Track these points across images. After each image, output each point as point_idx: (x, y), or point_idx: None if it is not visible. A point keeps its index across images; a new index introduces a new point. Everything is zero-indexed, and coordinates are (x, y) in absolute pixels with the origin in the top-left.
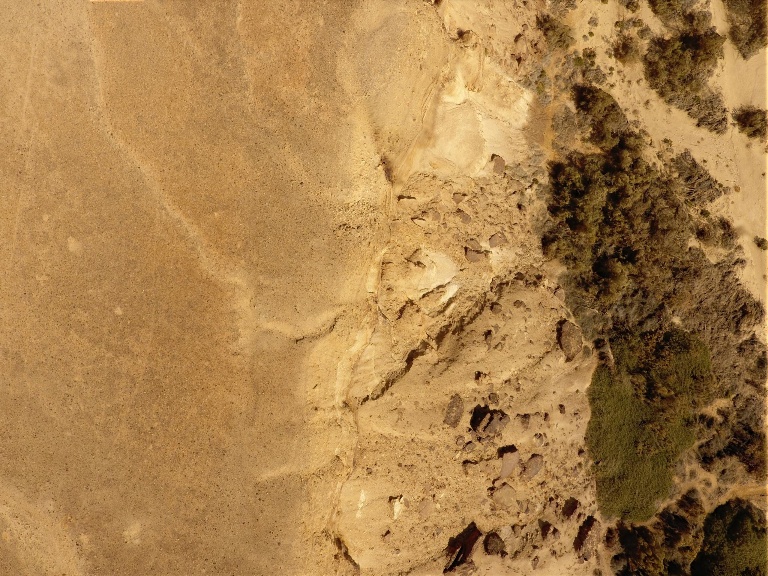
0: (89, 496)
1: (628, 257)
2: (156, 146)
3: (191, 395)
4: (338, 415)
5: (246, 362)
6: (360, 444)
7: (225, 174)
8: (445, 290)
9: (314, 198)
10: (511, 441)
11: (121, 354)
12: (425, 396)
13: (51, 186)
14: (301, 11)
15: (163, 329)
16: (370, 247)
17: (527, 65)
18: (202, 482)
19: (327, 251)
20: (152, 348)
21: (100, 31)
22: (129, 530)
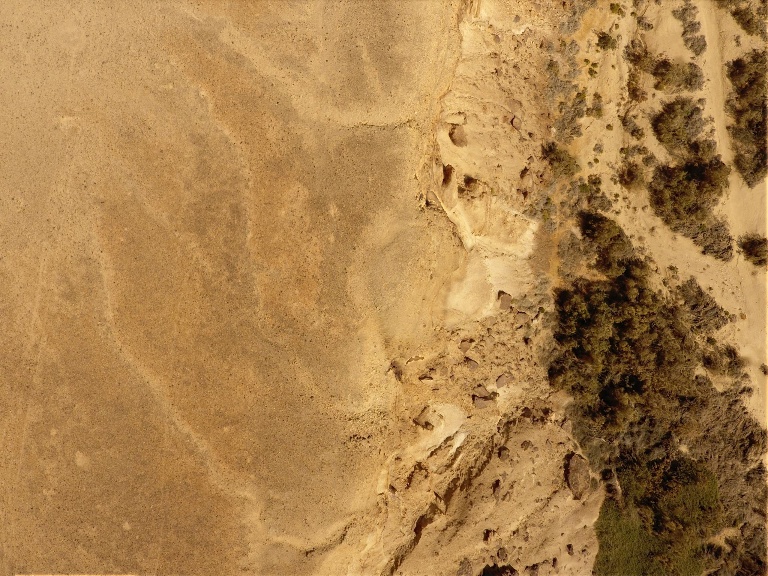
0: None
1: (635, 386)
2: (165, 361)
3: None
4: None
5: None
6: None
7: (235, 389)
8: (453, 443)
9: (324, 411)
10: None
11: (129, 569)
12: (434, 568)
13: (59, 401)
14: (311, 228)
15: (172, 544)
16: (380, 454)
17: (533, 195)
18: None
19: (337, 464)
20: (161, 564)
21: (109, 243)
22: None
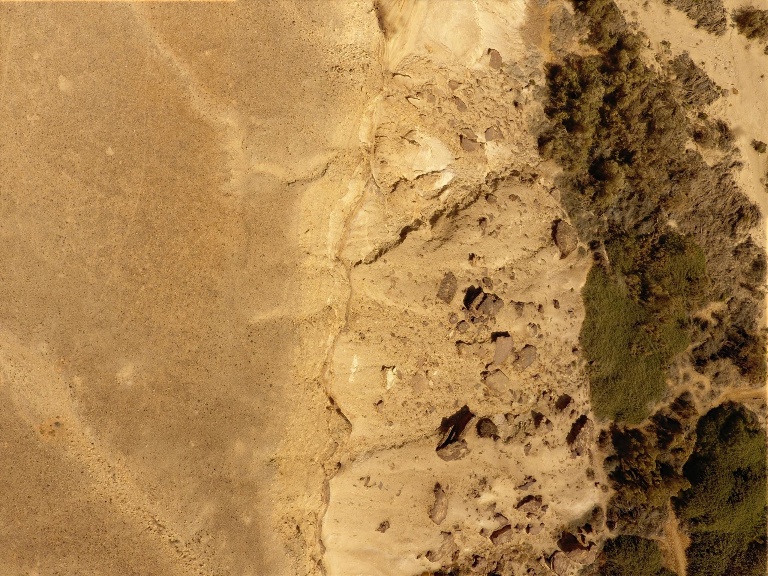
0: (82, 338)
1: (625, 159)
2: None
3: (183, 236)
4: (330, 266)
5: (238, 203)
6: (353, 308)
7: (216, 11)
8: (440, 175)
9: (306, 37)
10: (505, 327)
11: (113, 195)
12: (418, 268)
13: (41, 24)
14: None
15: (155, 169)
16: (363, 92)
17: None
18: (194, 323)
19: (319, 92)
20: (144, 189)
21: None
22: (122, 372)
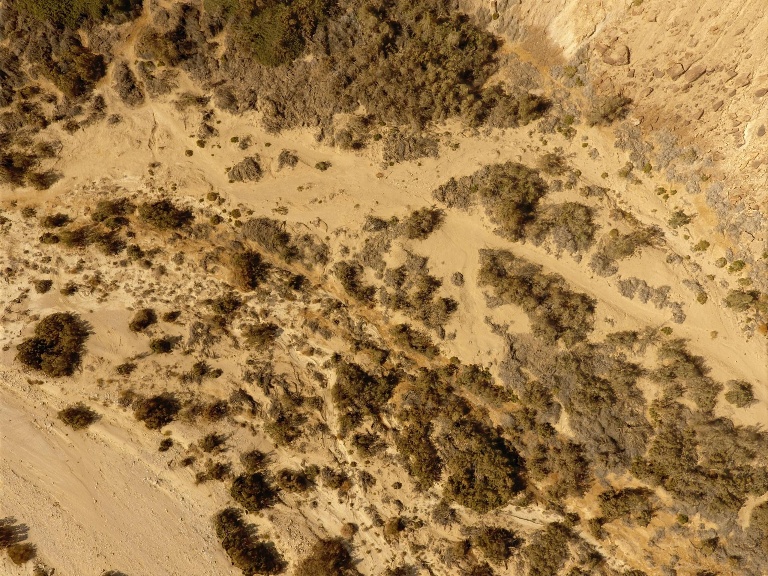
0: None
1: (385, 51)
2: None
3: None
4: None
5: None
6: None
7: None
8: None
9: None
10: None
11: None
12: None
13: None
14: None
15: None
16: None
17: (597, 66)
18: None
19: None
20: None
21: None
22: None
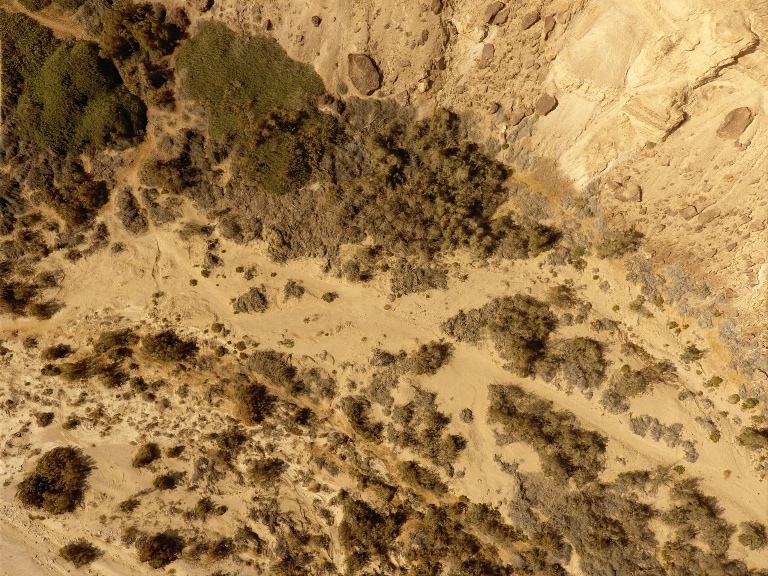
0: None
1: (393, 180)
2: None
3: None
4: None
5: None
6: None
7: None
8: None
9: None
10: None
11: None
12: None
13: None
14: None
15: None
16: None
17: (608, 199)
18: None
19: None
20: None
21: None
22: None
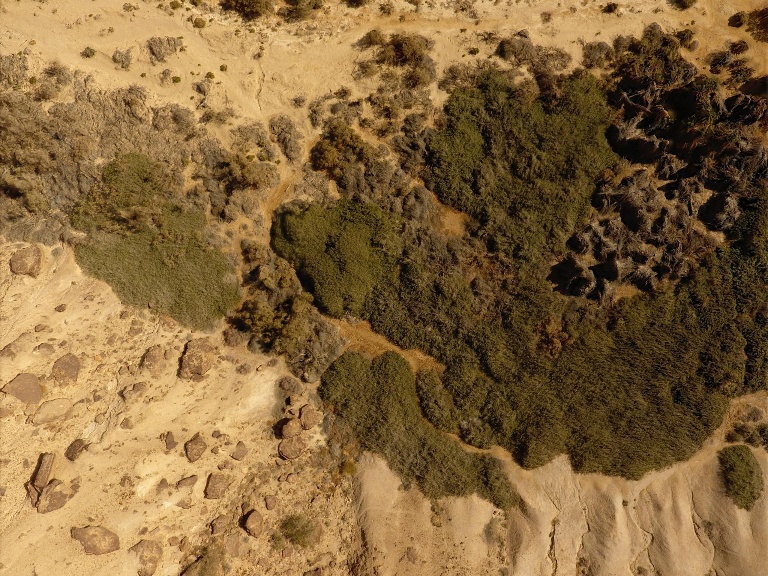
0: None
1: None
2: None
3: None
4: None
5: None
6: None
7: None
8: None
9: None
10: (12, 374)
11: None
12: None
13: None
14: None
15: None
16: None
17: None
18: None
19: None
20: None
21: None
22: None
